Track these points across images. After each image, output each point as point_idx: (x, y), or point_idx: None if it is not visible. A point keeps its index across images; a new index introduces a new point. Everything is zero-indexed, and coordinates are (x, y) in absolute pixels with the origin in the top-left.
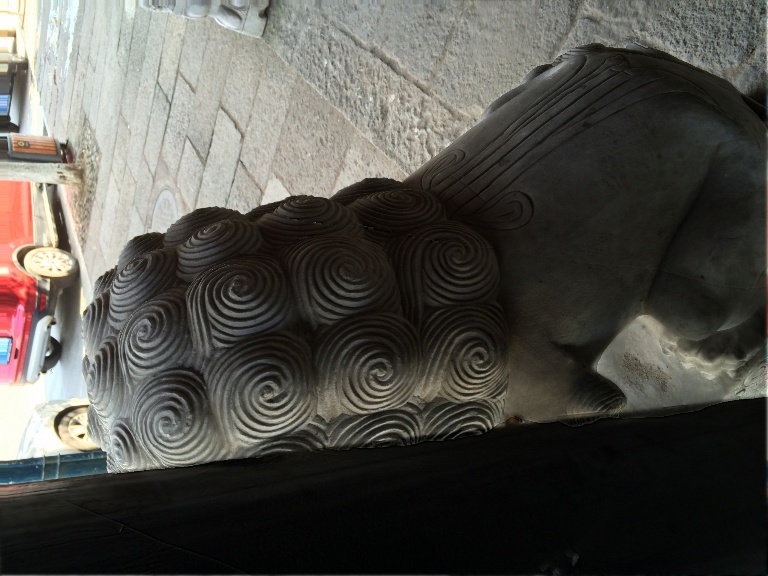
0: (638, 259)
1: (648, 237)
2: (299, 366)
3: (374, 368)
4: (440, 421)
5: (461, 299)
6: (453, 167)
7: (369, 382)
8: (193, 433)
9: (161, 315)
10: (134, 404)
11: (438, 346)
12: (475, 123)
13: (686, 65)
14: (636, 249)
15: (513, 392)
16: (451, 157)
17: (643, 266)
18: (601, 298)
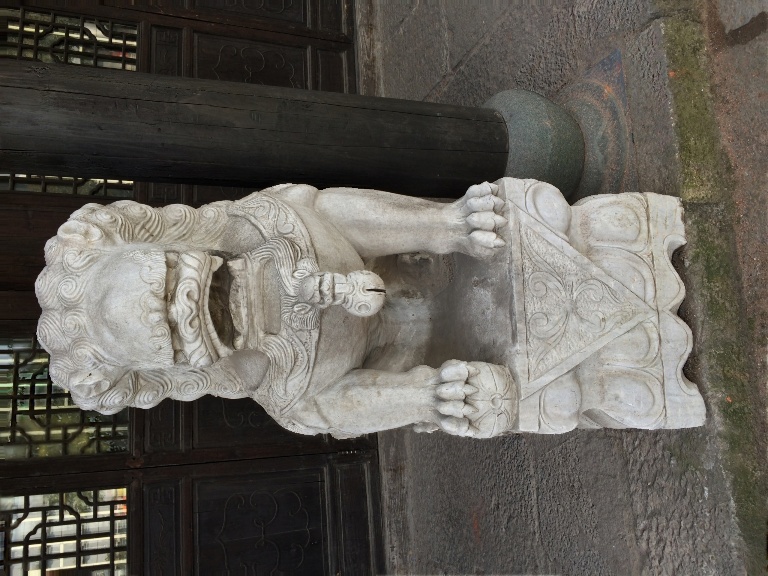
0: None
1: None
2: None
3: None
4: None
5: None
6: None
7: None
8: None
9: None
10: None
11: None
12: None
13: None
14: None
15: None
16: None
17: None
18: None
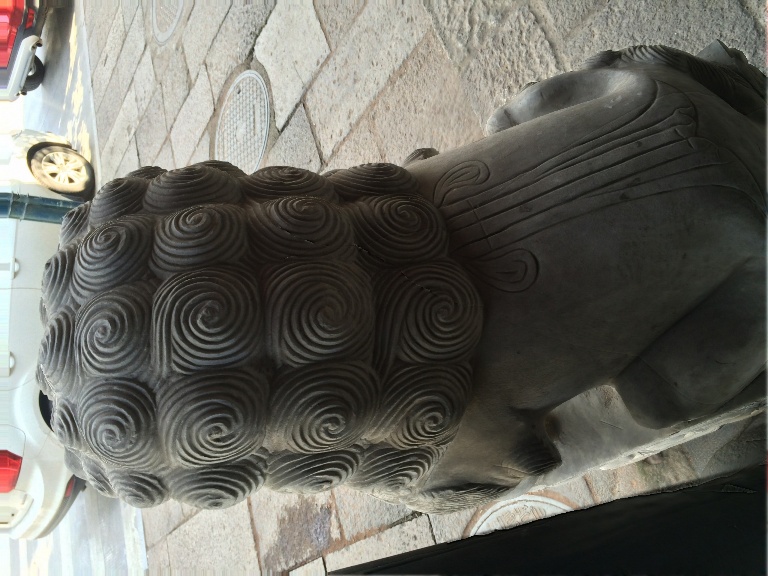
0: (622, 346)
1: (641, 329)
2: (253, 407)
3: (327, 422)
4: (380, 462)
5: (434, 358)
6: (472, 187)
7: (319, 432)
8: (135, 449)
9: (123, 320)
10: (82, 399)
11: (397, 403)
12: (528, 10)
13: (761, 107)
14: (624, 338)
15: (458, 442)
16: (474, 171)
17: (625, 352)
18: (572, 374)
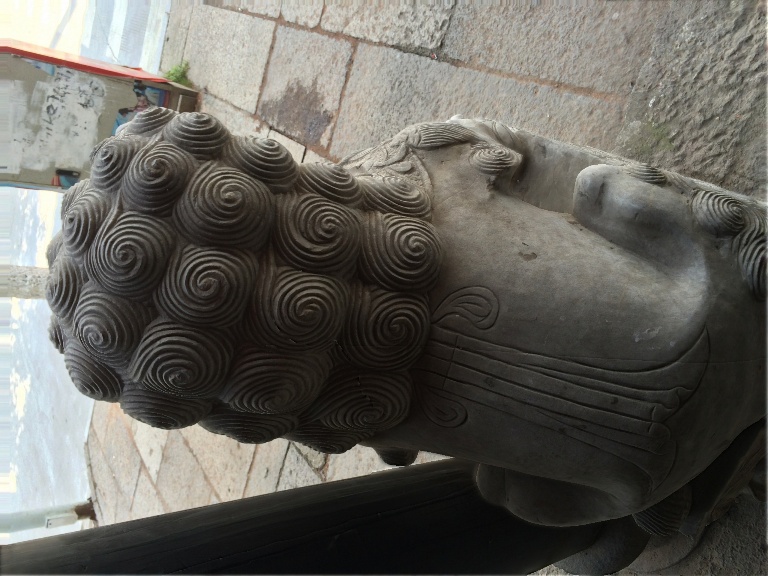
0: None
1: None
2: (193, 419)
3: (244, 440)
4: None
5: None
6: (470, 327)
7: None
8: None
9: (114, 340)
10: (71, 348)
11: None
12: None
13: None
14: None
15: None
16: (485, 310)
17: None
18: None
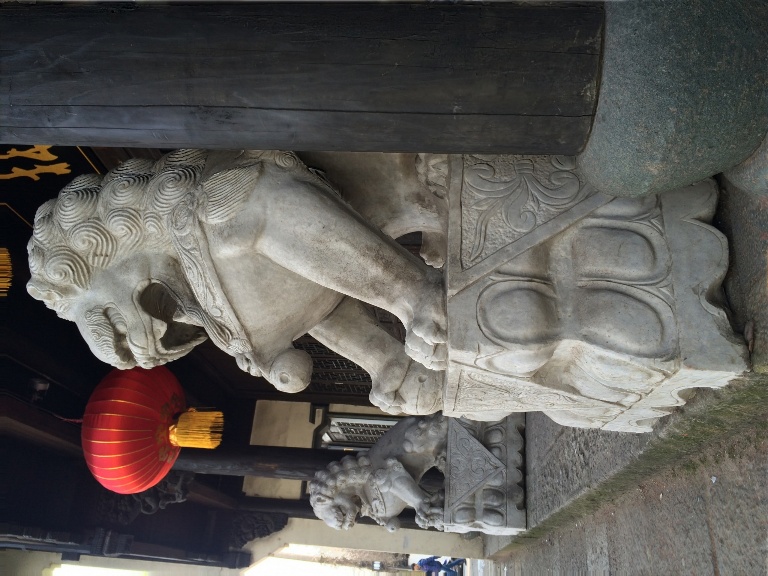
0: None
1: None
2: None
3: None
4: None
5: None
6: None
7: None
8: None
9: None
10: None
11: None
12: None
13: None
14: None
15: None
16: None
17: None
18: None
